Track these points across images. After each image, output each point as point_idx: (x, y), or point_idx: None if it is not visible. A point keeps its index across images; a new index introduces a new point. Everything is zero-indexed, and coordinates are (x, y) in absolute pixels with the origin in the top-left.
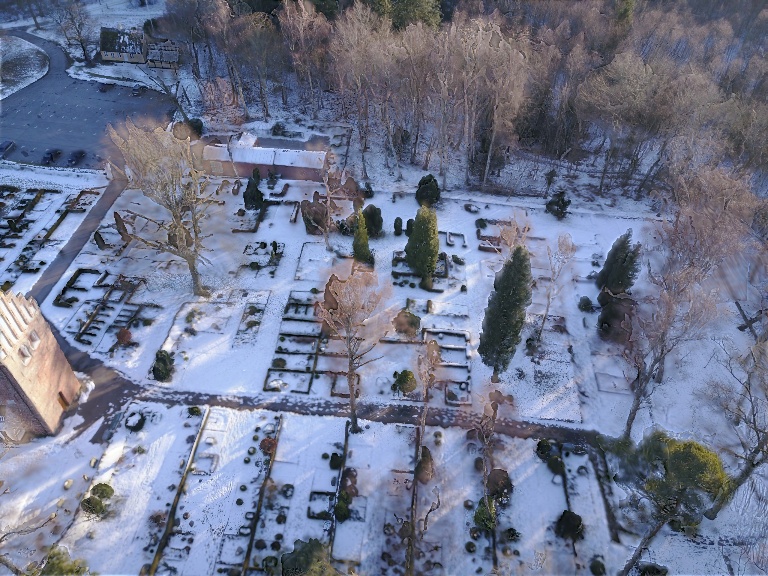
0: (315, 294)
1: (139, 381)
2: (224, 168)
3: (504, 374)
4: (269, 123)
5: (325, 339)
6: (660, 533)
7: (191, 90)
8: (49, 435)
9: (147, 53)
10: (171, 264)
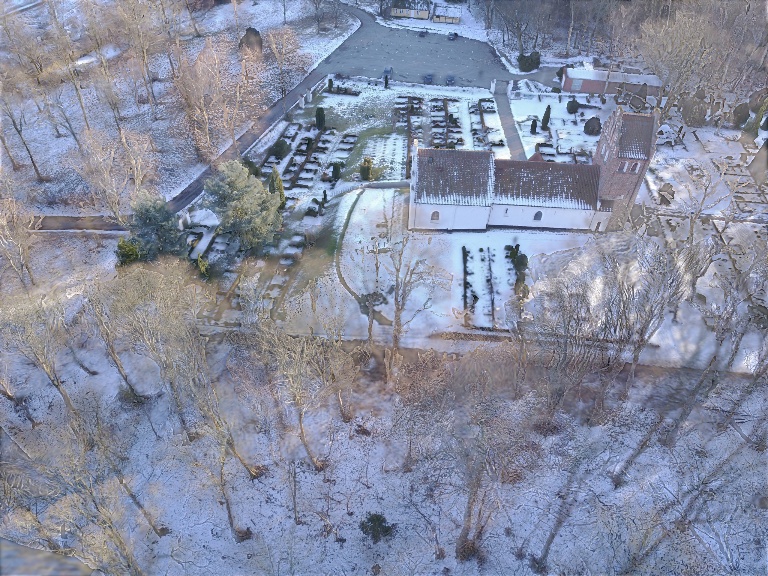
0: (731, 160)
1: (649, 205)
2: (582, 86)
3: None
4: (590, 58)
5: (763, 185)
6: None
7: (494, 37)
8: (619, 230)
9: (435, 10)
10: None
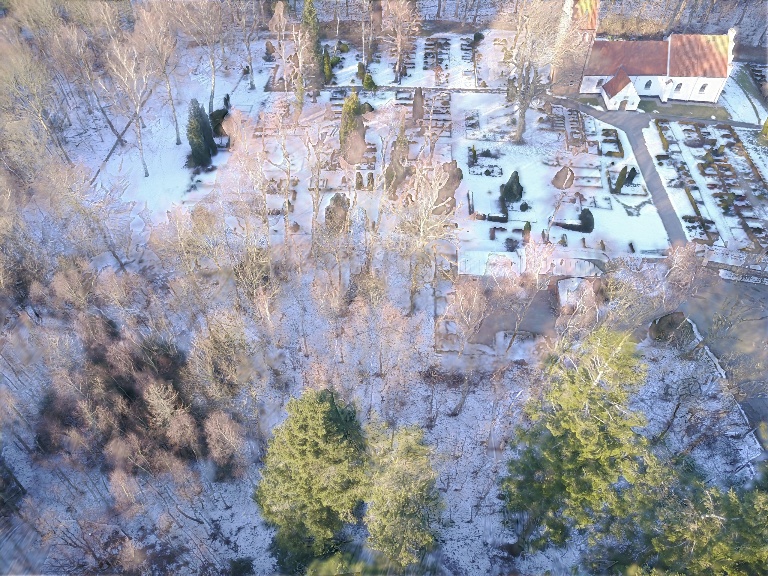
0: None
1: None
2: None
3: (308, 104)
4: None
5: None
6: (256, 68)
7: None
8: None
9: None
10: (556, 161)
